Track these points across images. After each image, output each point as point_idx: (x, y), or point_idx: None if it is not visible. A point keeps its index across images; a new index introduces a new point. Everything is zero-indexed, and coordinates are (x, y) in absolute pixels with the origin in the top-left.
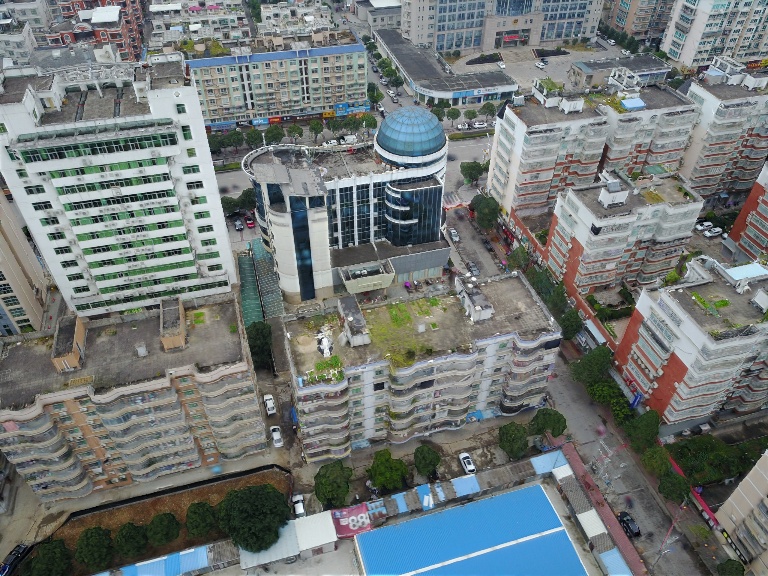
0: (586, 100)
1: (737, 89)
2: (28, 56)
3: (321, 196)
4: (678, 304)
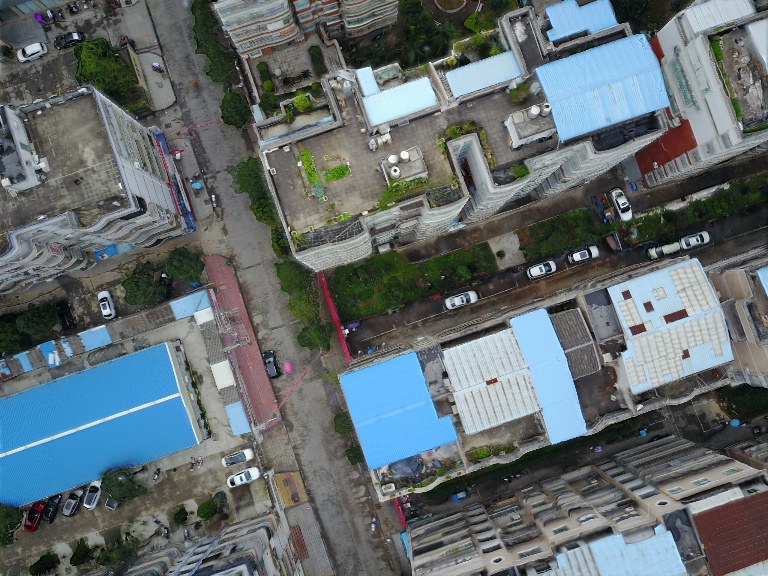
0: None
1: None
2: None
3: None
4: None
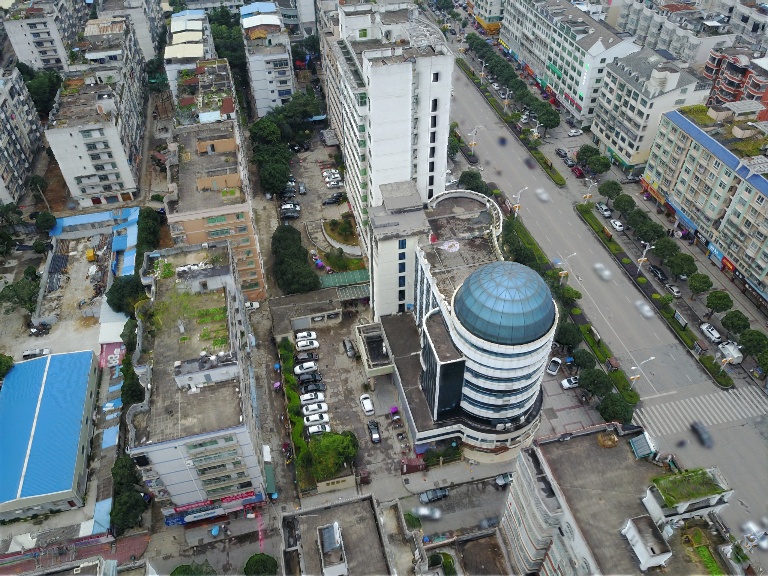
0: None
1: None
2: (689, 60)
3: None
4: None
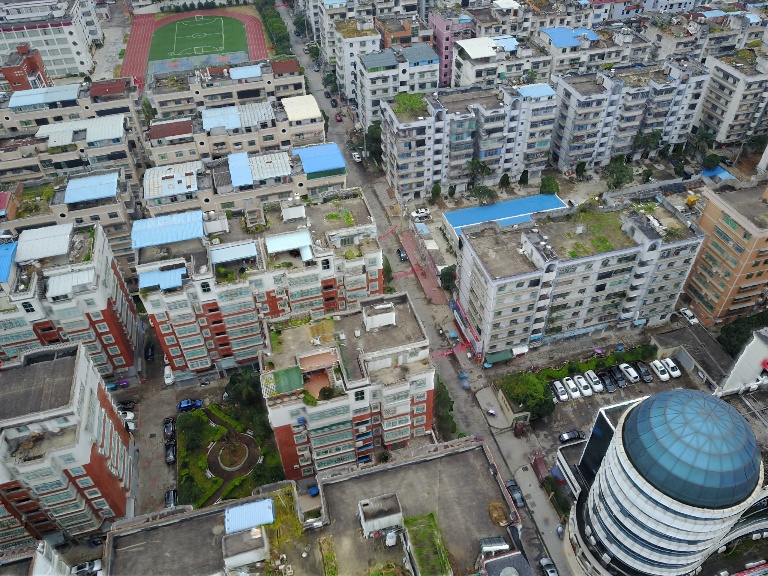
0: (332, 573)
1: None
2: None
3: None
4: None
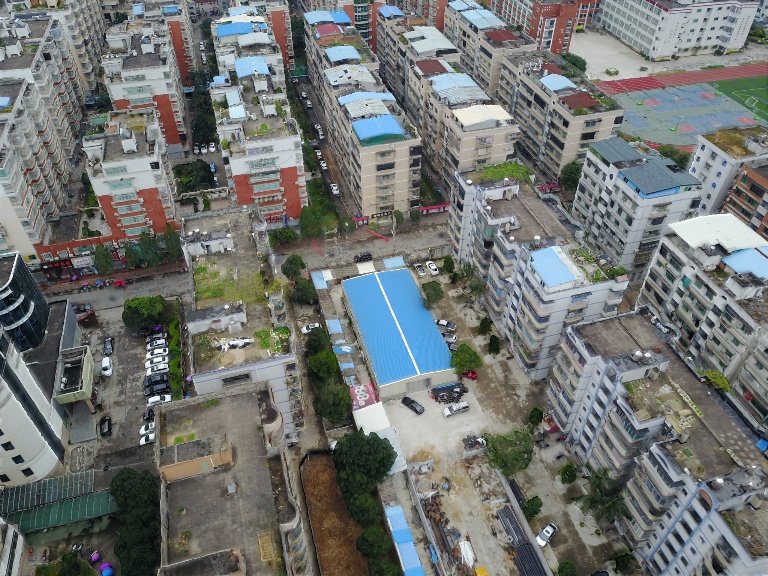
0: None
1: (13, 60)
2: None
3: (2, 334)
4: (263, 140)
